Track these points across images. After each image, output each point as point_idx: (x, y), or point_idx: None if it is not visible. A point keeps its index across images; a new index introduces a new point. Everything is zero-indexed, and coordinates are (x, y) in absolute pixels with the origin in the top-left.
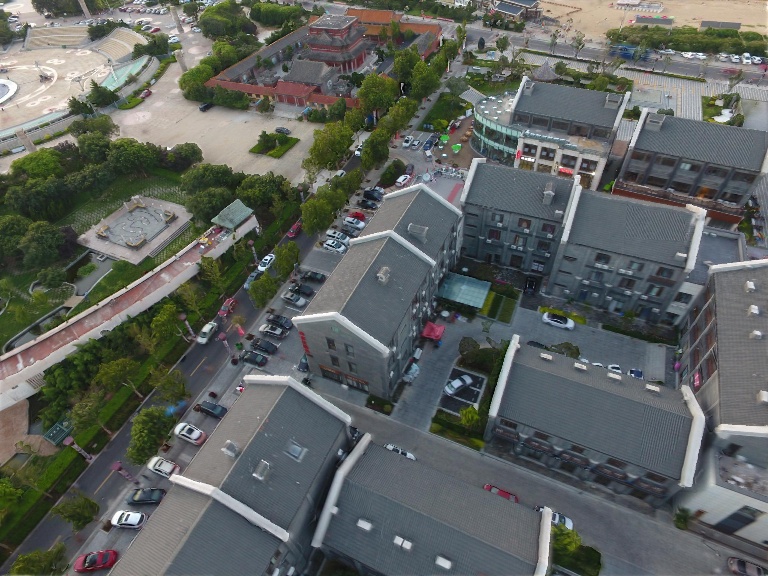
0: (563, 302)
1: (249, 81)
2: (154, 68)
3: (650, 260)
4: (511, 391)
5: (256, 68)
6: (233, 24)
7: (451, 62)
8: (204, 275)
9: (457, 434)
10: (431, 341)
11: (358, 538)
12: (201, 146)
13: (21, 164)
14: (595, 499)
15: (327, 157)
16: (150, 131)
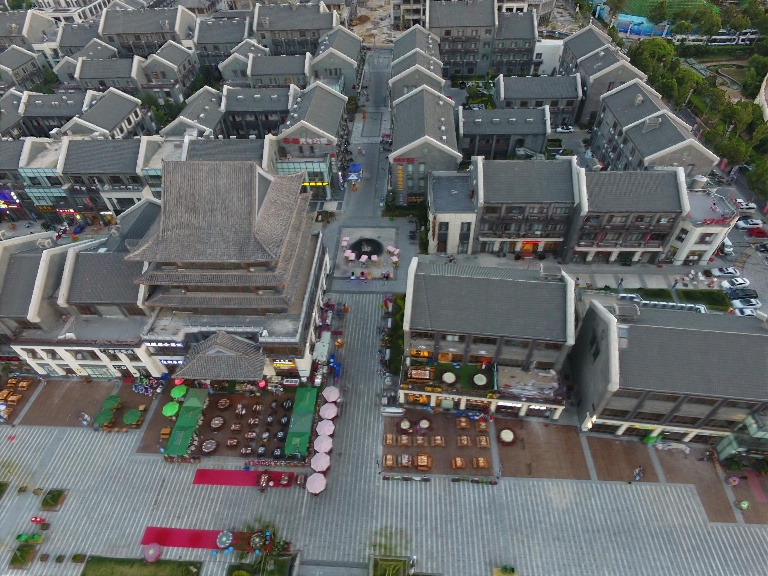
0: None
1: None
2: None
3: None
4: None
5: None
6: None
7: None
8: None
9: None
10: None
11: None
12: None
13: None
14: None
15: None
16: None
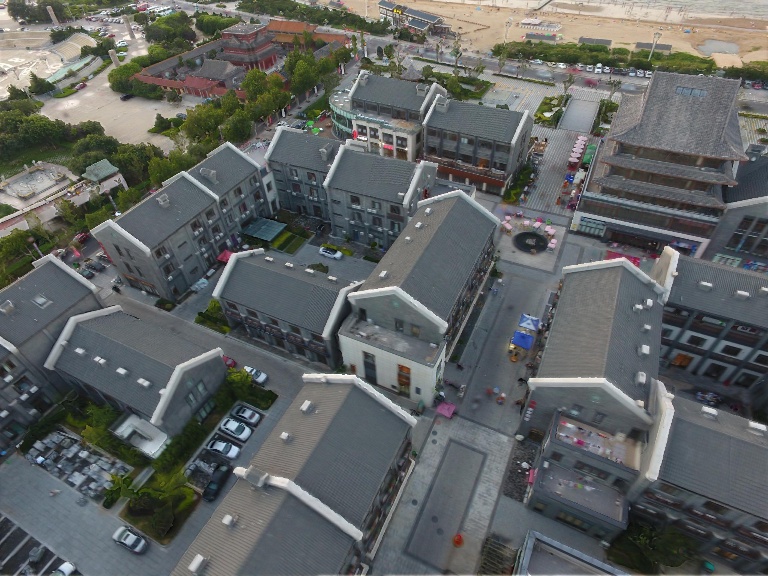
0: (343, 241)
1: (169, 77)
2: (96, 66)
3: (382, 199)
4: (232, 280)
5: (179, 67)
6: (175, 32)
7: (350, 66)
8: (58, 211)
9: (213, 323)
10: None
11: (77, 362)
12: (110, 127)
13: None
14: (294, 364)
15: (194, 132)
16: (73, 115)
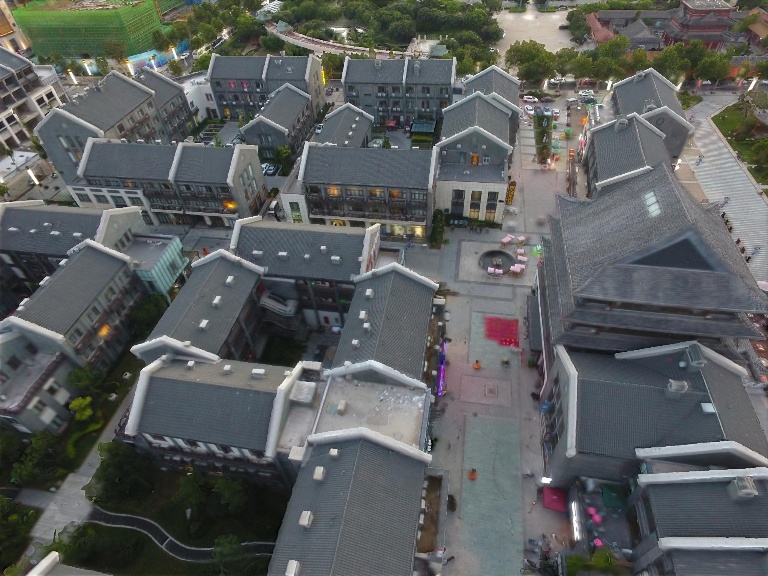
0: None
1: None
2: None
3: None
4: None
5: (633, 21)
6: None
7: None
8: None
9: None
10: (385, 126)
11: None
12: None
13: (448, 4)
14: None
15: None
16: (521, 24)
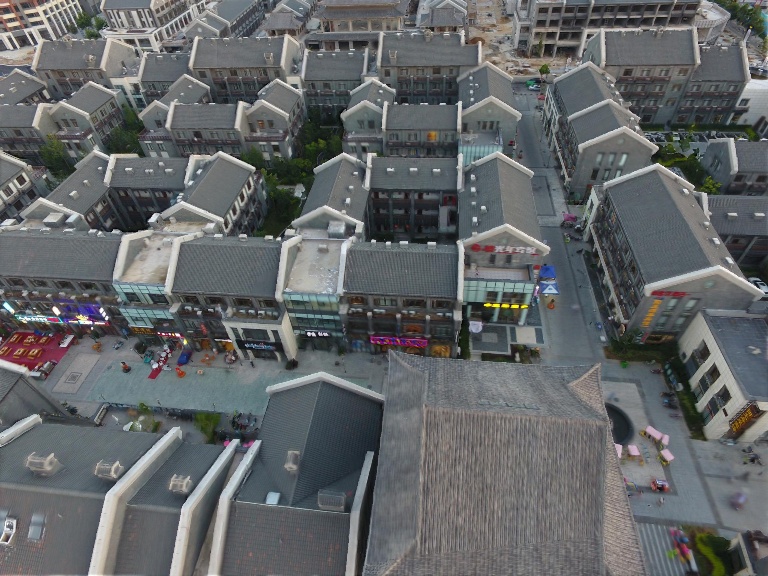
0: None
1: None
2: None
3: None
4: None
5: None
6: None
7: None
8: None
9: None
10: None
11: None
12: None
13: None
14: None
15: None
16: None
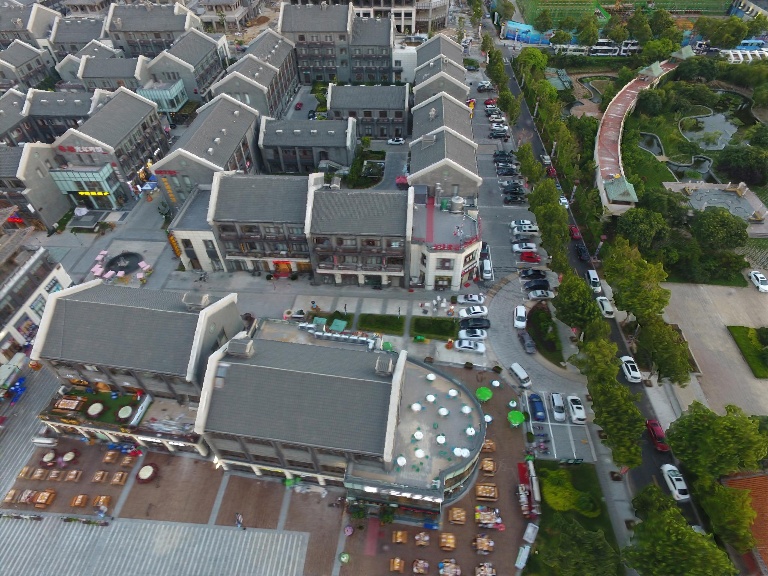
0: None
1: None
2: None
3: None
4: None
5: None
6: None
7: None
8: None
9: None
10: None
11: None
12: None
13: None
14: None
15: None
16: None
